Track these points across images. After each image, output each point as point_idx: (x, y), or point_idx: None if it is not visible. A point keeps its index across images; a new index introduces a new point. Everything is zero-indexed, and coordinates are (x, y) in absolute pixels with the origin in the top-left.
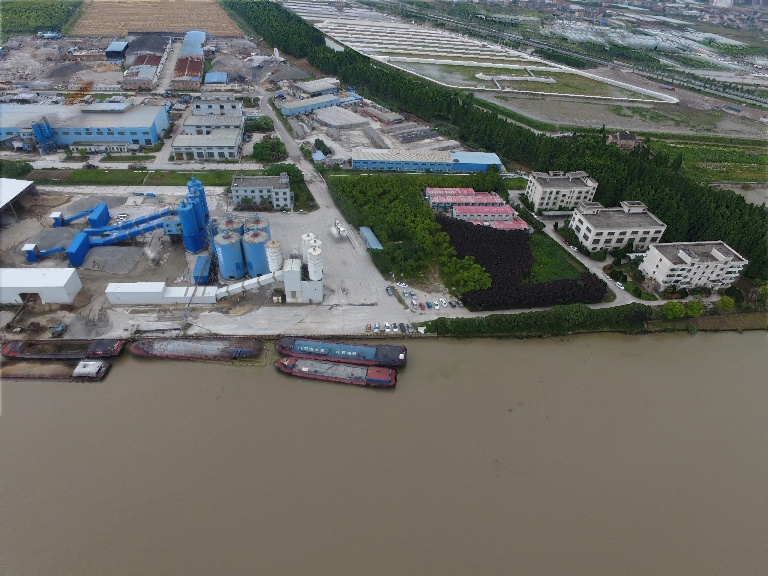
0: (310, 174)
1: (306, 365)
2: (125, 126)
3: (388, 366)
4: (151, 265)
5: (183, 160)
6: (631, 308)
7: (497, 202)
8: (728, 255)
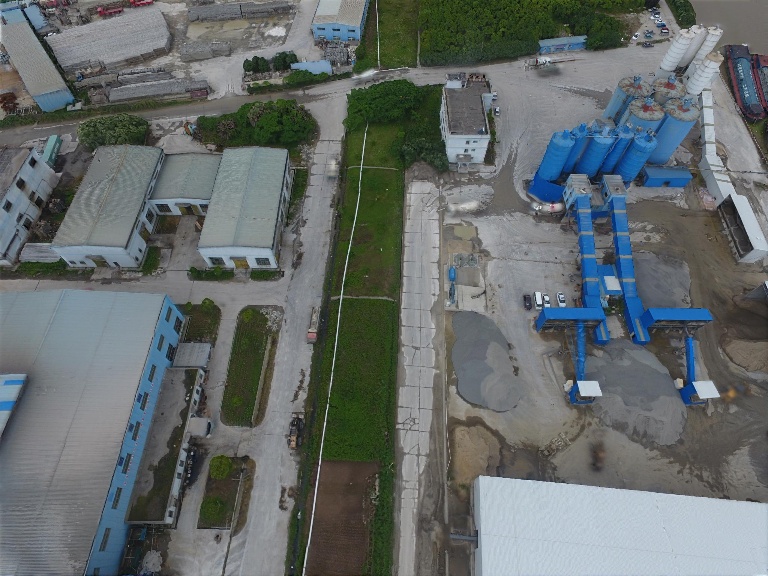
0: (377, 82)
1: None
2: (138, 354)
3: (752, 57)
4: (660, 237)
5: (281, 252)
6: None
7: None
8: None
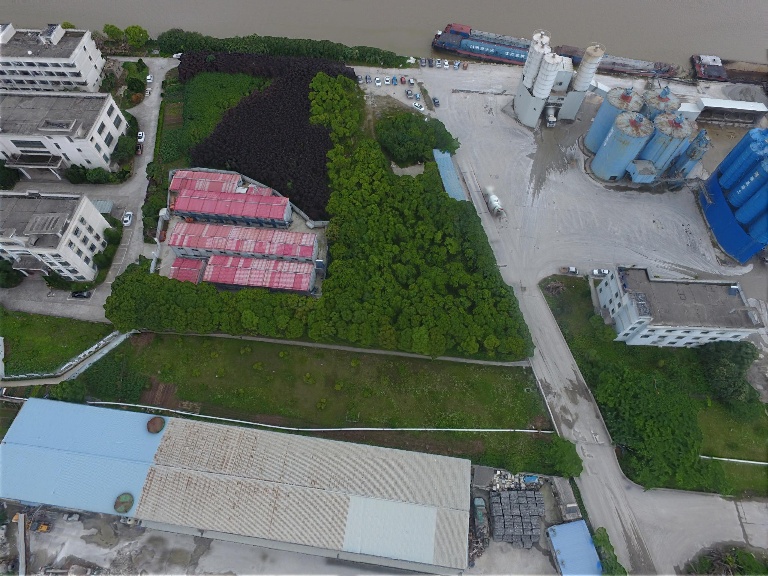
0: (583, 435)
1: (524, 39)
2: None
3: None
4: None
5: None
6: (185, 33)
7: (186, 223)
8: (0, 26)
